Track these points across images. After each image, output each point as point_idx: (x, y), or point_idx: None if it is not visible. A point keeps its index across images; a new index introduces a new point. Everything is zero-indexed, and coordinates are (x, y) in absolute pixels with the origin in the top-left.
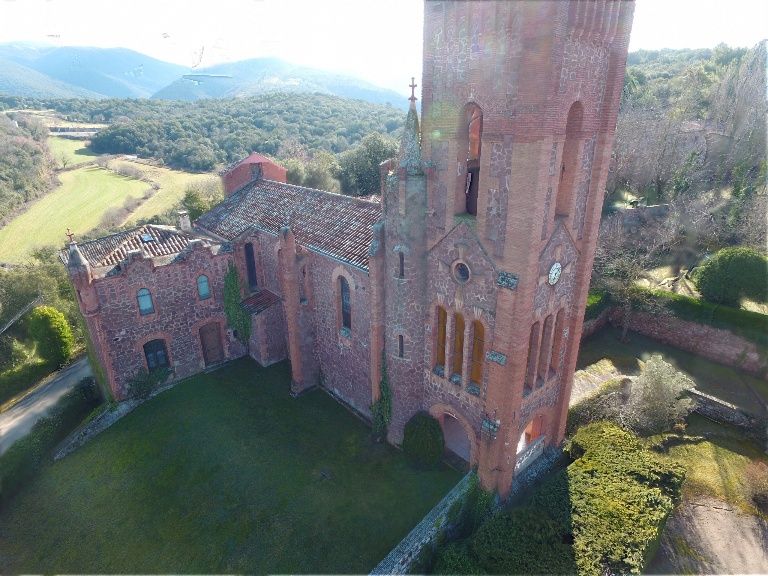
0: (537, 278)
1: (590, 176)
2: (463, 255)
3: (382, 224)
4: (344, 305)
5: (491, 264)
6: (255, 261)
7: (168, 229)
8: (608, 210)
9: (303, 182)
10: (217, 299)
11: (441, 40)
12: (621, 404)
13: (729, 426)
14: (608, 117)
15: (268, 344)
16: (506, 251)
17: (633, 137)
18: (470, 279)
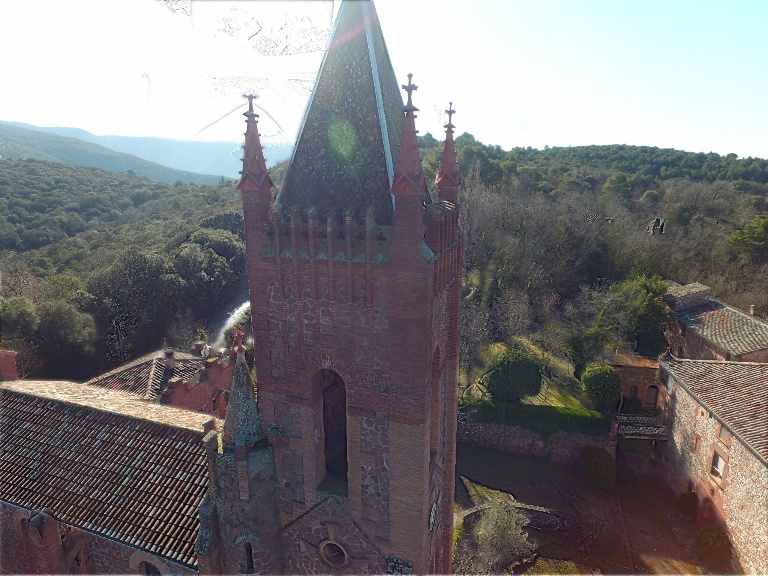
0: None
1: (445, 399)
2: (334, 536)
3: (213, 507)
4: None
5: (375, 548)
6: None
7: None
8: None
9: (36, 328)
10: None
11: (277, 294)
12: (473, 557)
13: (548, 530)
14: (456, 344)
15: None
16: (393, 535)
17: None
18: (347, 563)
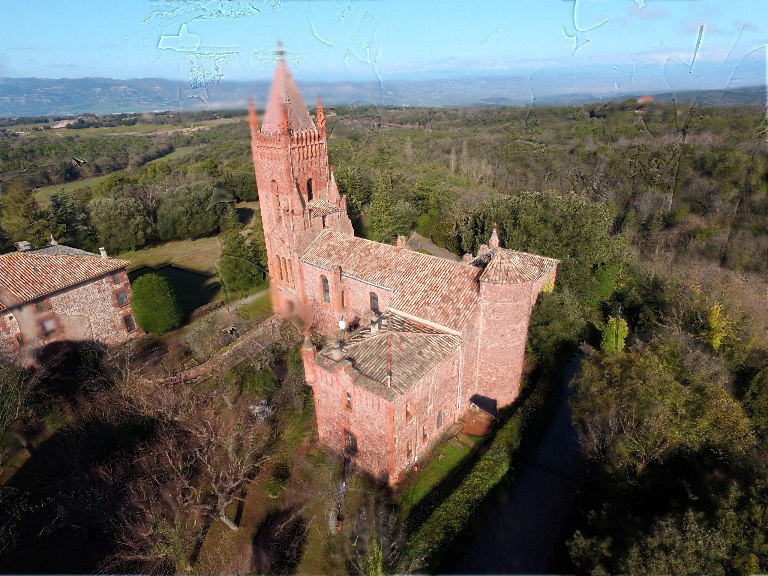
0: None
1: None
2: None
3: None
4: None
5: None
6: None
7: None
8: None
9: None
10: None
11: None
12: None
13: None
14: None
15: None
16: None
17: None
18: None
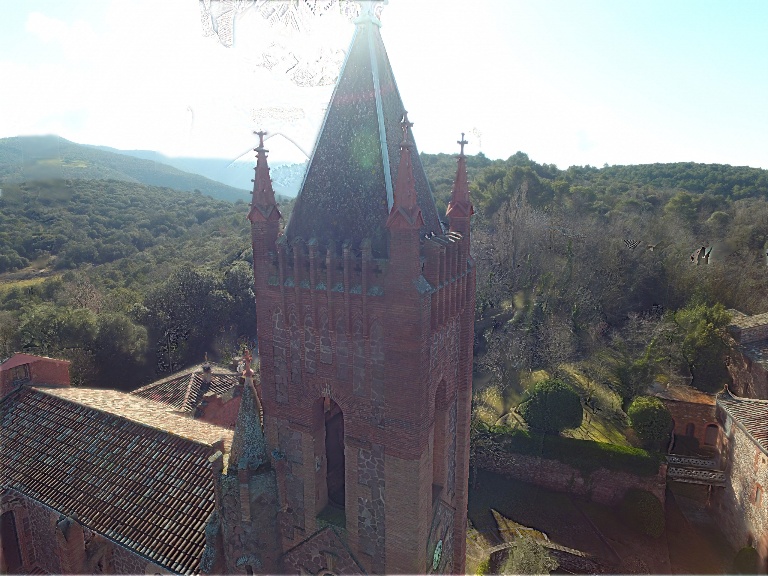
0: None
1: (455, 432)
2: (333, 566)
3: (218, 526)
4: None
5: None
6: (18, 532)
7: None
8: None
9: (95, 338)
10: None
11: (281, 321)
12: None
13: None
14: (466, 376)
15: None
16: (388, 571)
17: None
18: None
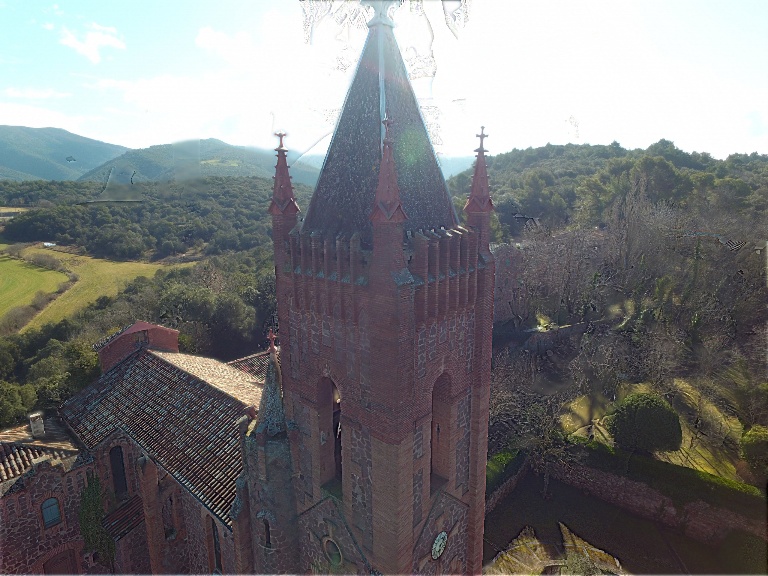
0: (417, 564)
1: (469, 428)
2: (333, 534)
3: (245, 481)
4: (216, 544)
5: (361, 556)
6: (124, 464)
7: (14, 435)
8: (523, 336)
9: (213, 314)
10: (70, 521)
11: None
12: None
13: None
14: (480, 373)
15: (135, 570)
16: (375, 548)
17: (538, 269)
18: (342, 563)
